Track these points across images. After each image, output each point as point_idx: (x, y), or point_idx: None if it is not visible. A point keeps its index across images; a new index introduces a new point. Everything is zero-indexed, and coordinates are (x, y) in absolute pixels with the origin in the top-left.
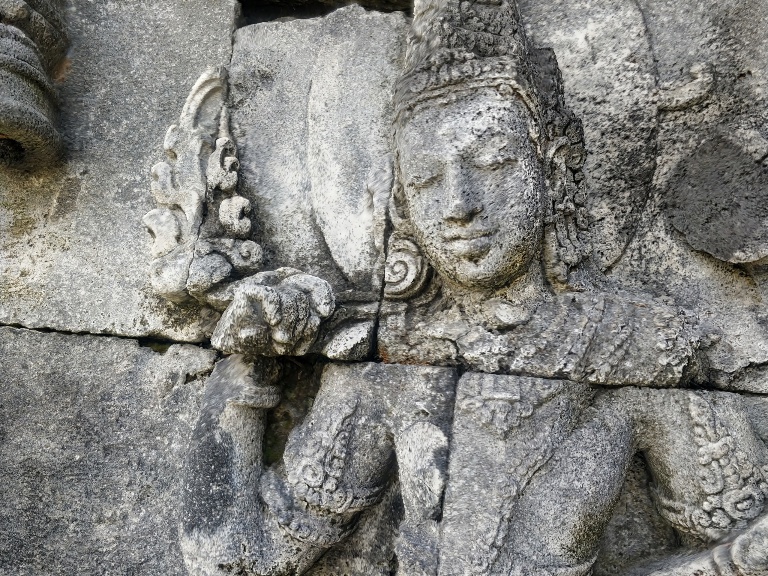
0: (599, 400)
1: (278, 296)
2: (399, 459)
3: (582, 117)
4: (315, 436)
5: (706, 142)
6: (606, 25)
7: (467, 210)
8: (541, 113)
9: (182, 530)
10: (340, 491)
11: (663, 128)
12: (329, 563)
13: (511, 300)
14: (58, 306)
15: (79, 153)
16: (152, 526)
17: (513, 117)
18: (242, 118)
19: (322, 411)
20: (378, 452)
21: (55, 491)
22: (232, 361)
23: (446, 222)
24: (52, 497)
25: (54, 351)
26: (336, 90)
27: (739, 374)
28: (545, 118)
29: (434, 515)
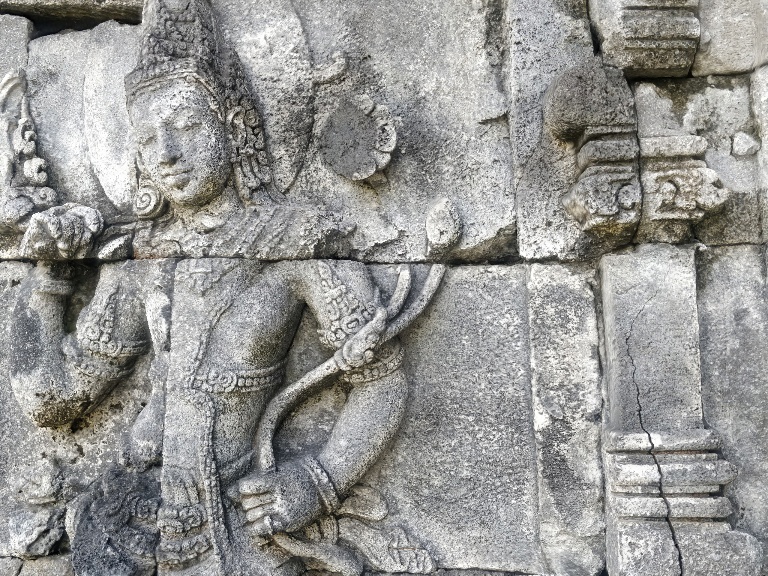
0: (265, 270)
1: (58, 220)
2: (147, 318)
3: (265, 91)
4: (93, 309)
5: (340, 104)
6: (277, 29)
7: (169, 157)
8: (218, 92)
9: (11, 375)
10: (112, 342)
11: (318, 96)
12: (117, 395)
13: (212, 213)
14: None
15: None
16: None
17: (196, 97)
18: (38, 104)
19: (99, 294)
20: (137, 317)
21: None
22: (38, 267)
23: (161, 165)
24: None
25: None
26: (102, 81)
27: (369, 251)
28: (223, 95)
29: (166, 348)
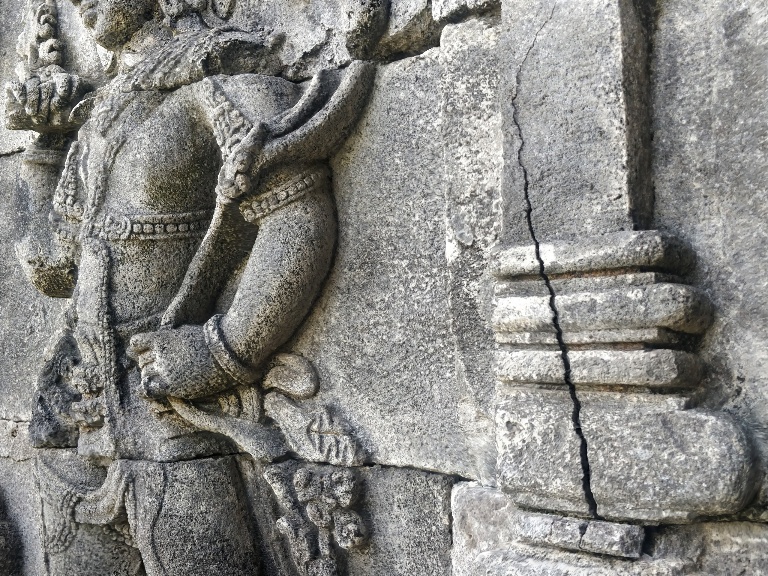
0: (164, 100)
1: (20, 85)
2: None
3: None
4: None
5: None
6: None
7: None
8: None
9: None
10: (76, 204)
11: None
12: None
13: (134, 50)
14: (1, 140)
15: (1, 43)
16: None
17: None
18: None
19: None
20: None
21: (8, 250)
22: None
23: (78, 7)
24: (7, 254)
25: (2, 167)
26: None
27: (300, 65)
28: None
29: None
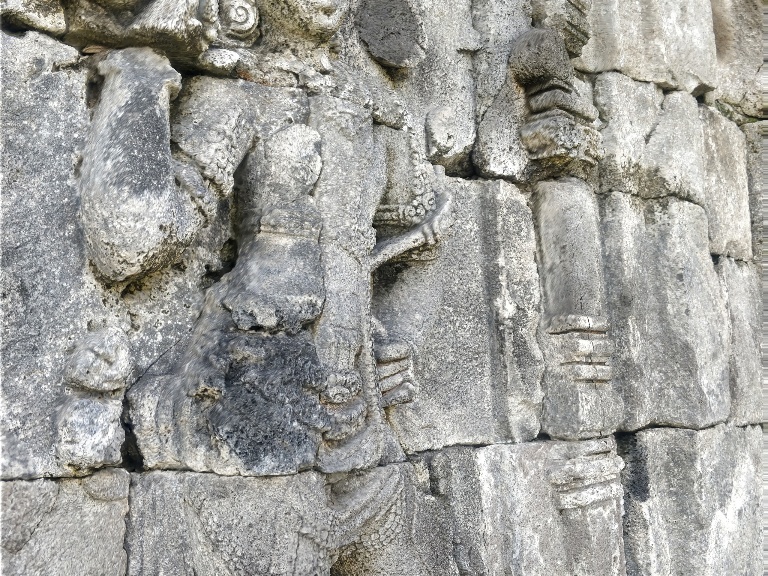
0: (375, 130)
1: None
2: (272, 154)
3: None
4: (216, 128)
5: None
6: None
7: None
8: None
9: (125, 194)
10: (232, 175)
11: None
12: None
13: None
14: None
15: None
16: (26, 210)
17: None
18: None
19: (207, 112)
20: (245, 151)
21: None
22: (136, 53)
23: None
24: None
25: None
26: None
27: None
28: None
29: None
